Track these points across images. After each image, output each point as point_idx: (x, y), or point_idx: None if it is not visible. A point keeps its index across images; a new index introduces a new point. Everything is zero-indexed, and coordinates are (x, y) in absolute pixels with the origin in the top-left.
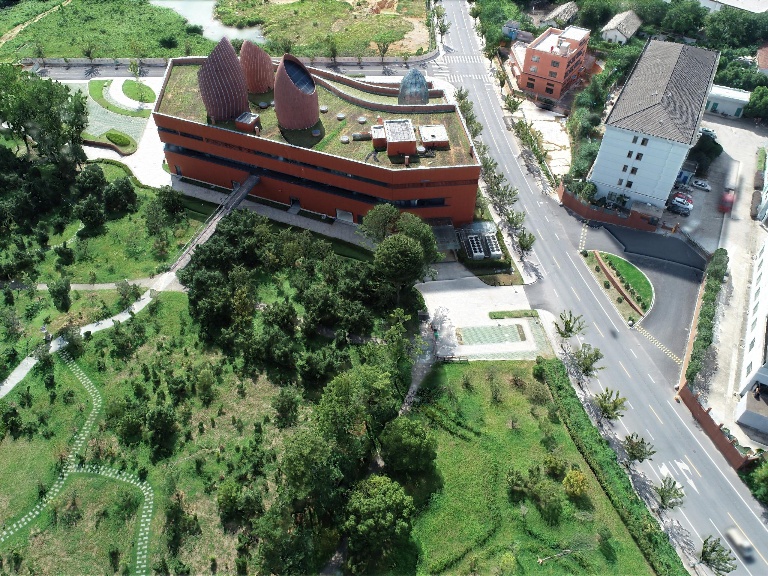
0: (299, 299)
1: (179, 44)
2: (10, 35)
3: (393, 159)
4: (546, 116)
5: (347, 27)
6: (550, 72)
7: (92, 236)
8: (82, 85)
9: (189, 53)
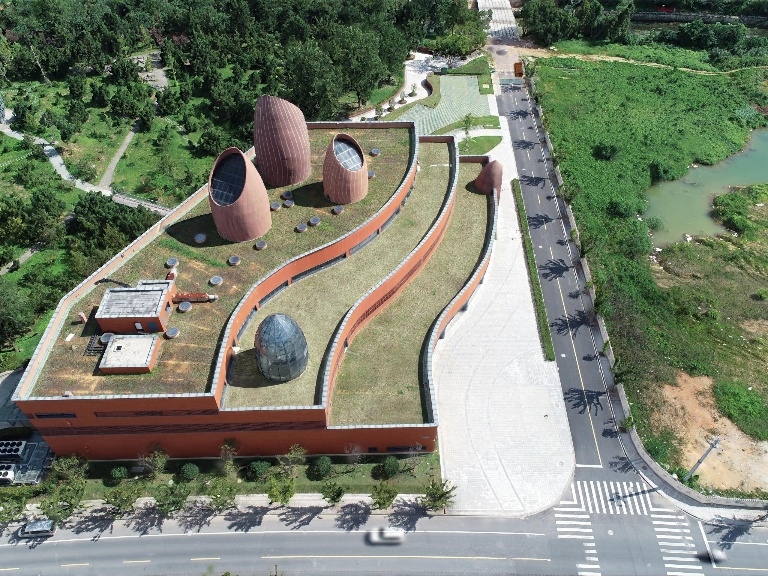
0: (29, 278)
1: (609, 161)
2: (595, 58)
3: None
4: None
5: (760, 340)
6: None
7: (192, 152)
8: (485, 113)
9: (556, 164)
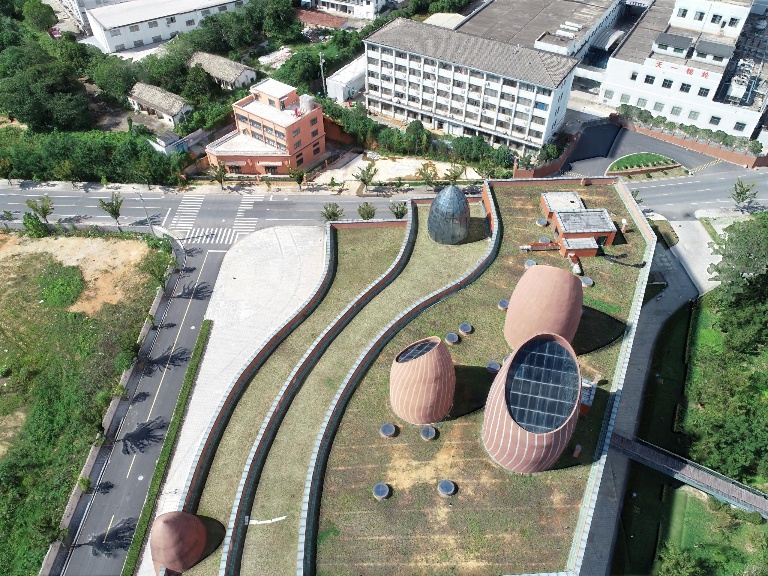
0: None
1: None
2: None
3: (617, 242)
4: (362, 166)
5: None
6: (312, 133)
7: None
8: None
9: None
